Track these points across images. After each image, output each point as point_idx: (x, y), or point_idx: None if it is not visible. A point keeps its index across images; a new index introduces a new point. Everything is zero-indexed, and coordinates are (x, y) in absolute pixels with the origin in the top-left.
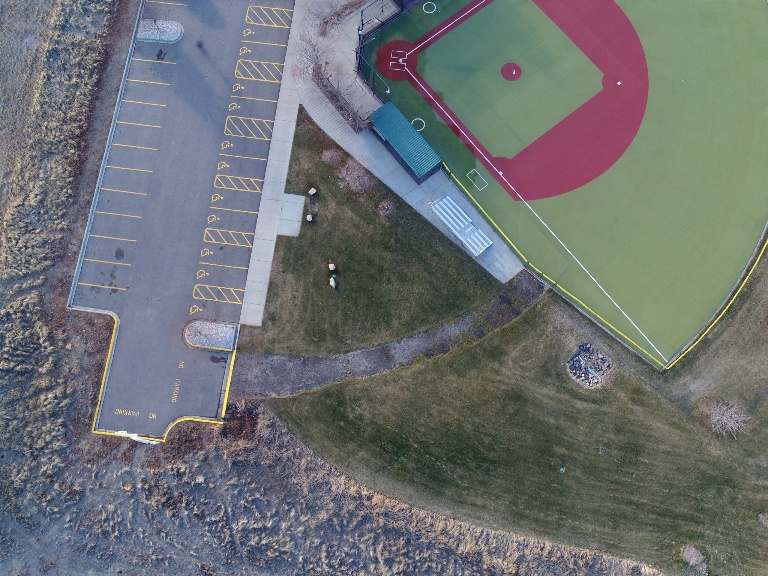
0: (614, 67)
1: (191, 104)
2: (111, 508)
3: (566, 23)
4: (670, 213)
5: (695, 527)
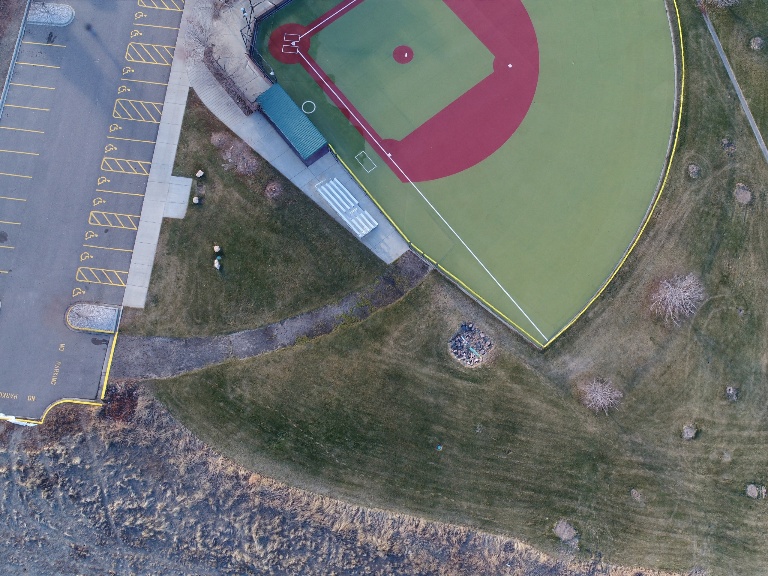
0: (505, 50)
1: (80, 87)
2: None
3: (459, 6)
4: (556, 194)
5: (569, 503)
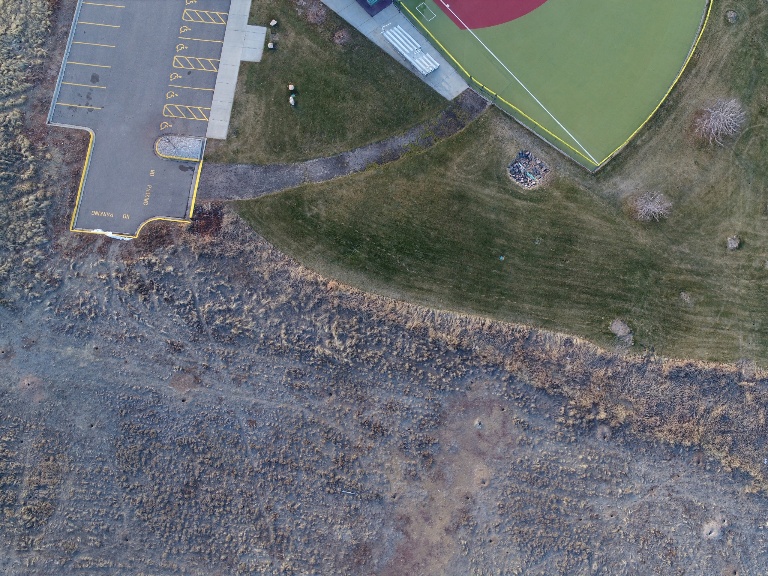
0: None
1: None
2: (88, 294)
3: None
4: (603, 38)
5: (623, 304)
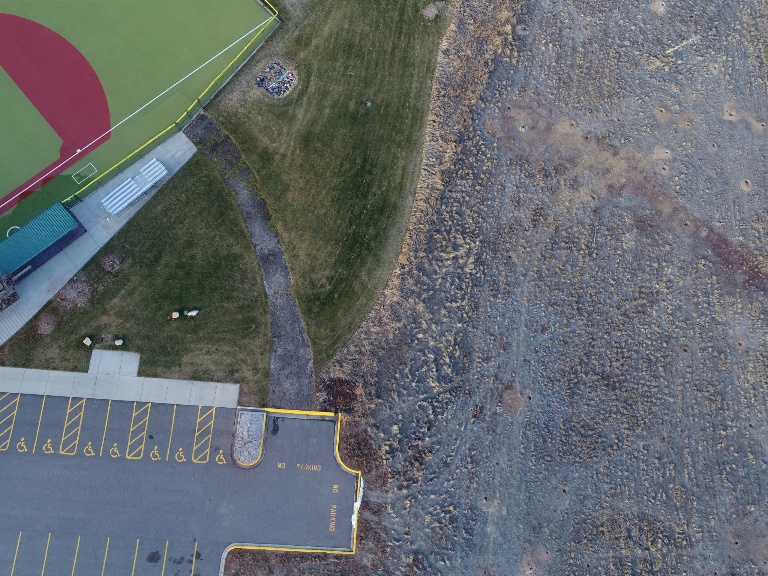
0: None
1: None
2: (428, 518)
3: None
4: (130, 4)
5: (409, 7)
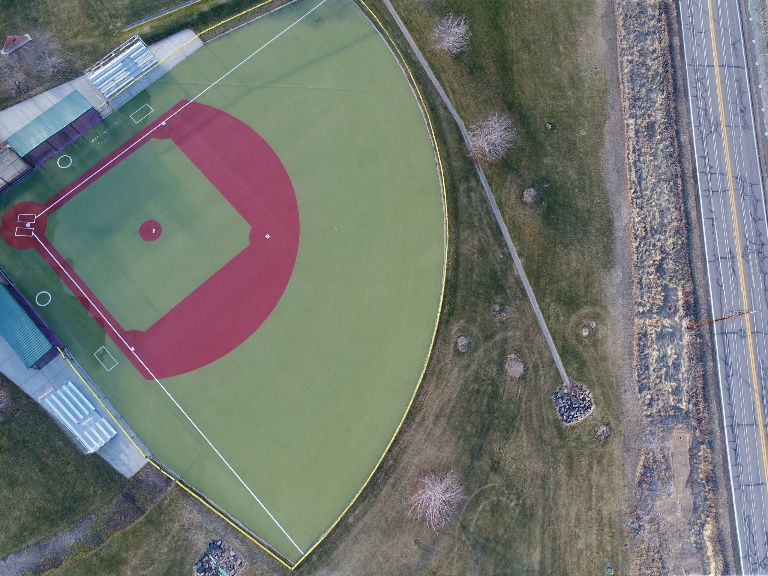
0: (263, 218)
1: None
2: None
3: (214, 171)
4: (315, 381)
5: None
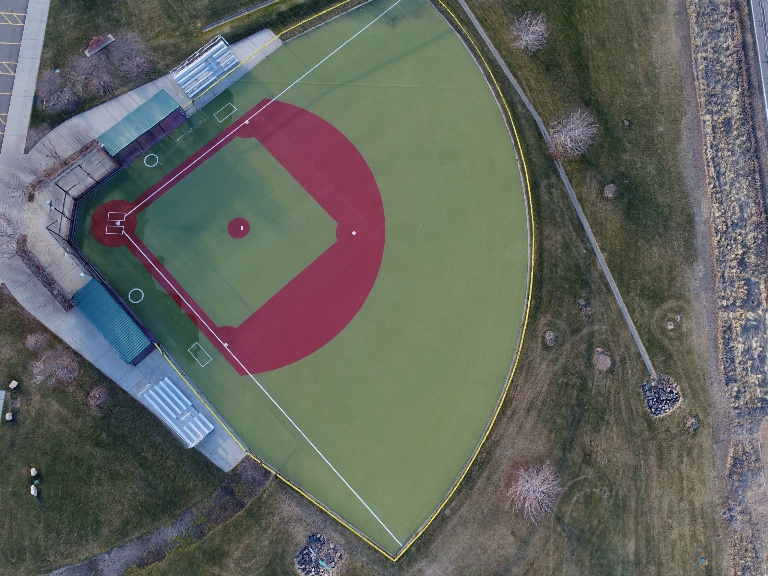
0: (349, 215)
1: None
2: None
3: (298, 169)
4: (406, 376)
5: None
